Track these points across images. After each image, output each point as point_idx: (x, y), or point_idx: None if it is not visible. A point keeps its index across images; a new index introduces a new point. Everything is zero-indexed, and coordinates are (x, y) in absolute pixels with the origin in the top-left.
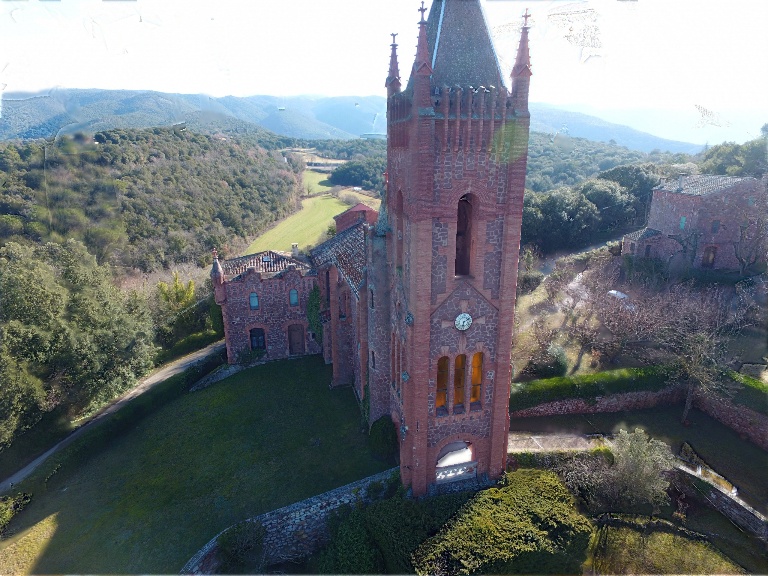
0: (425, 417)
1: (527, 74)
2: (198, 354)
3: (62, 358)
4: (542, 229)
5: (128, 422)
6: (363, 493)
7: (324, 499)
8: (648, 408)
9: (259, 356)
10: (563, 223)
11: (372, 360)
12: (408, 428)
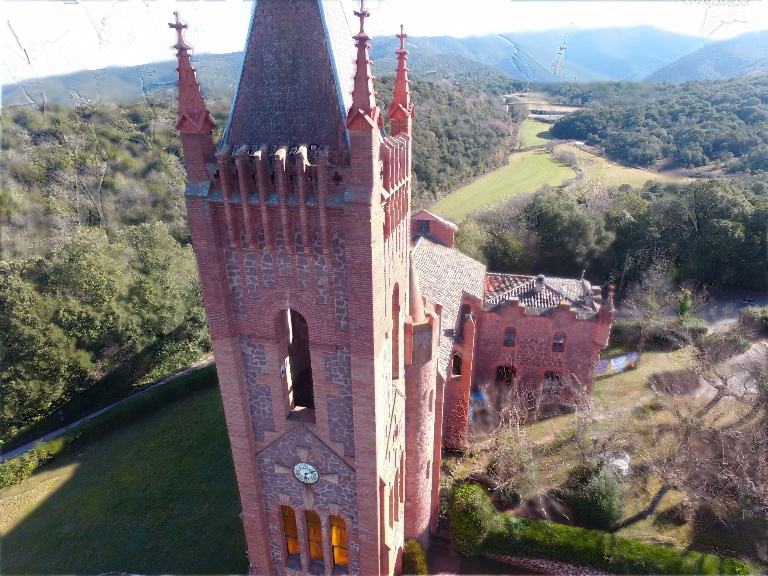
0: (265, 564)
1: (365, 126)
2: None
3: (115, 335)
4: (740, 254)
5: (157, 402)
6: None
7: None
8: None
9: None
10: None
11: None
12: (252, 565)
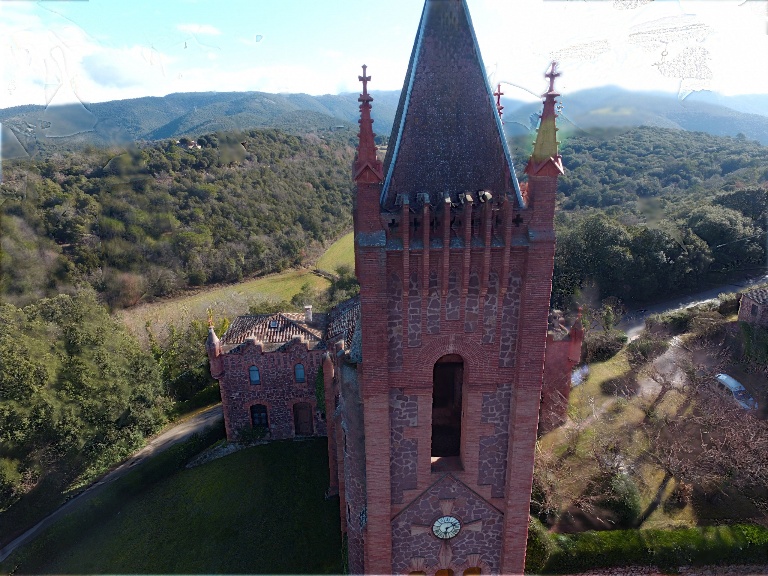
0: None
1: (552, 171)
2: (215, 409)
3: (46, 433)
4: (631, 273)
5: (109, 506)
6: None
7: None
8: None
9: (261, 435)
10: (660, 265)
11: (348, 512)
12: None
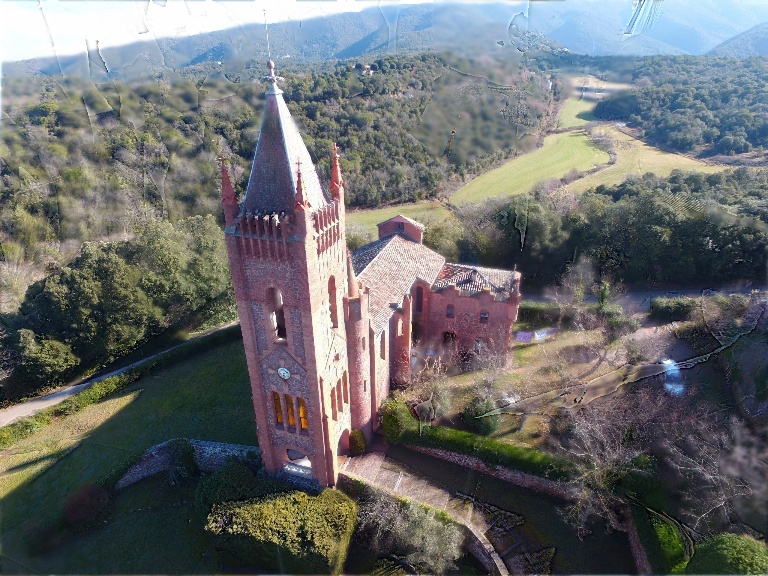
0: (265, 426)
1: (302, 209)
2: None
3: (178, 297)
4: (667, 254)
5: (206, 346)
6: (245, 454)
7: (222, 447)
8: (563, 499)
9: None
10: (705, 251)
11: None
12: (258, 428)
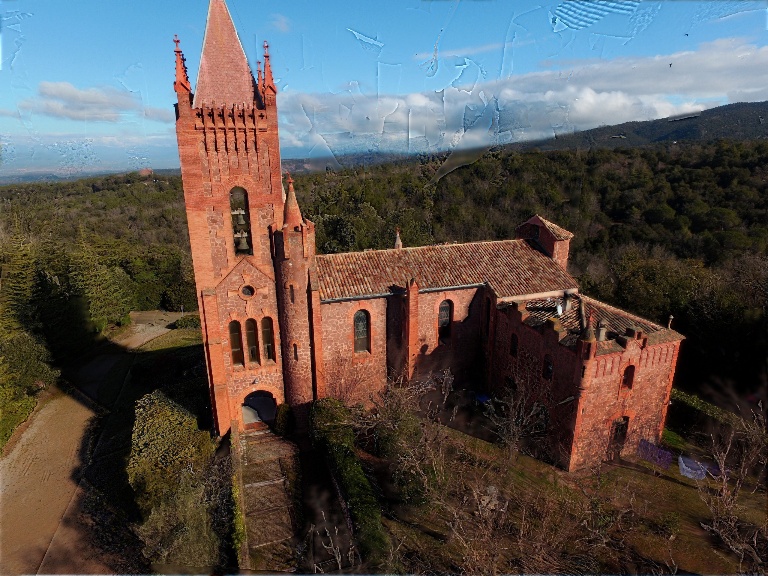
0: None
1: None
2: None
3: None
4: None
5: None
6: None
7: None
8: None
9: None
10: None
11: None
12: None
